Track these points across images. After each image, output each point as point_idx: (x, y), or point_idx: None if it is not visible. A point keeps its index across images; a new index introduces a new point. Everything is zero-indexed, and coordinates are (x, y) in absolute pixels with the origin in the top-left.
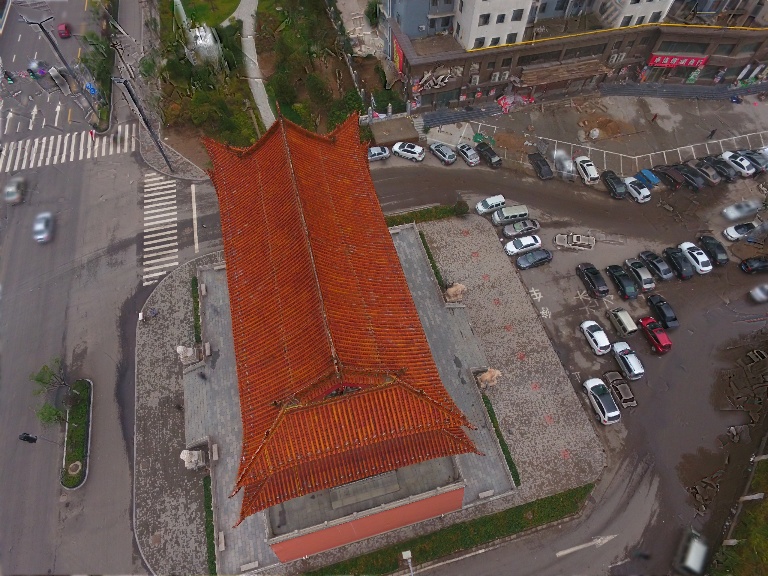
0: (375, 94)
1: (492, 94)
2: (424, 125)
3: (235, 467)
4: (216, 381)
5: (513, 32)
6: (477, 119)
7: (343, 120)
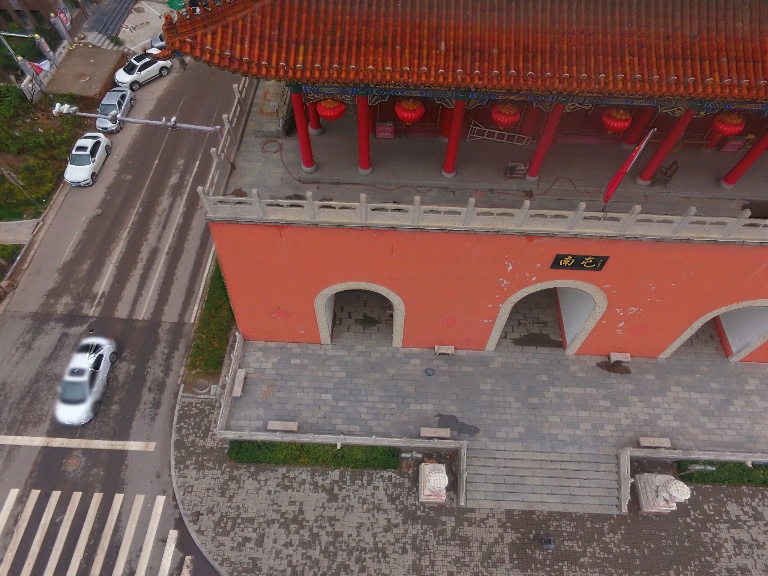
0: None
1: None
2: (107, 37)
3: (676, 414)
4: (506, 428)
5: None
6: None
7: (1, 117)
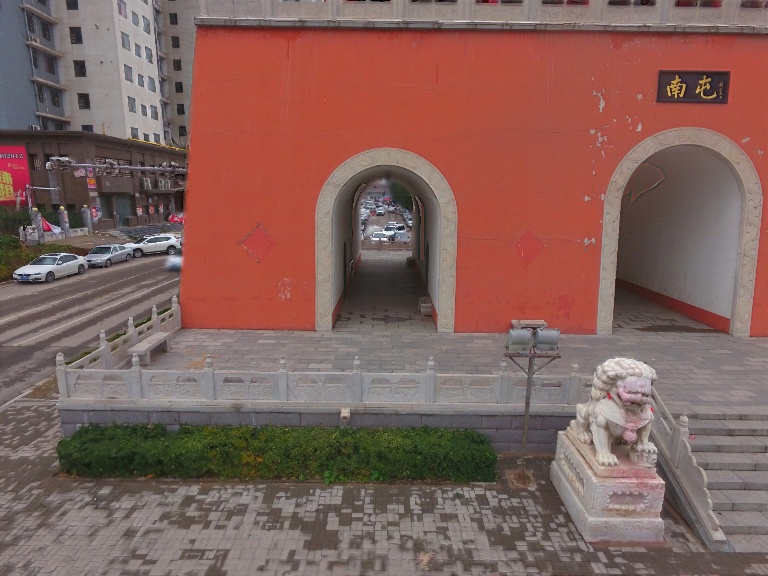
0: (5, 216)
1: (161, 212)
2: (127, 235)
3: None
4: (713, 391)
5: (156, 133)
6: (173, 231)
7: None
